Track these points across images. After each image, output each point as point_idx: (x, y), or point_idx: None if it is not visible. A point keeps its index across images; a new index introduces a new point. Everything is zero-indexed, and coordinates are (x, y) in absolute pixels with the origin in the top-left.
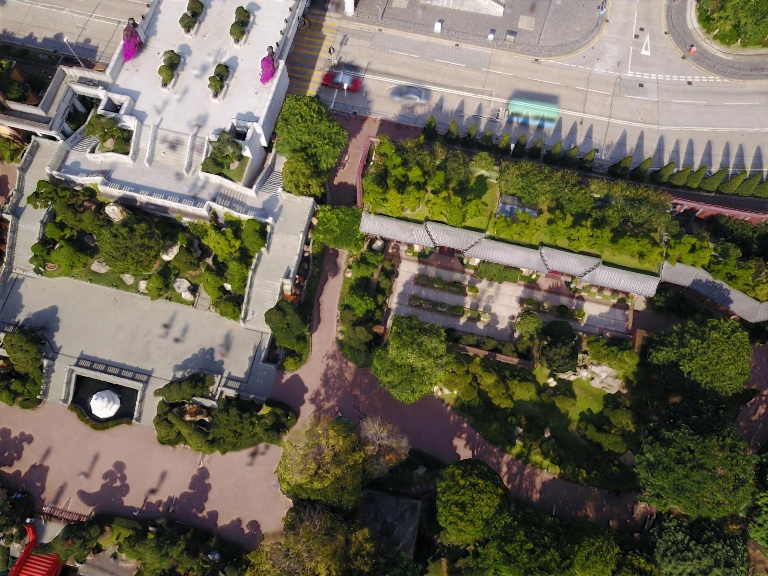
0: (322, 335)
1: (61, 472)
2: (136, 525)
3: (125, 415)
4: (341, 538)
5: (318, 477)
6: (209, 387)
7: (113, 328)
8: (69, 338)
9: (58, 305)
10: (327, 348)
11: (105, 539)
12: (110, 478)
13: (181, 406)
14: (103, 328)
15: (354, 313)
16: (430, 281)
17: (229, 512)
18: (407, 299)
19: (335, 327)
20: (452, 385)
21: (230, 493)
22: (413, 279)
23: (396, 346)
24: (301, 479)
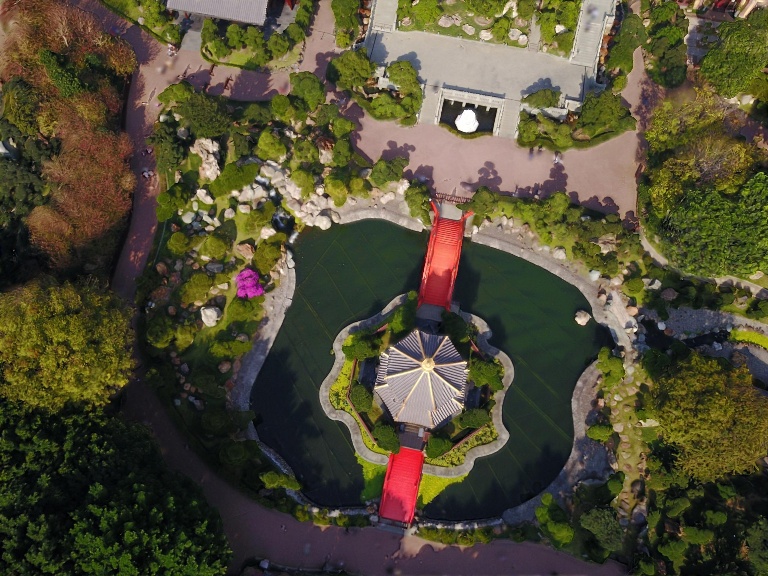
0: (633, 68)
1: (443, 170)
2: (518, 200)
3: (484, 130)
4: (742, 145)
5: (704, 117)
6: (557, 101)
7: (465, 66)
8: (431, 74)
9: (416, 51)
10: (640, 77)
11: (493, 213)
12: (484, 173)
13: (533, 118)
14: (456, 67)
15: (668, 42)
16: (710, 29)
17: (586, 192)
18: (694, 43)
19: (642, 62)
20: (756, 89)
21: (584, 179)
22: (696, 29)
23: (737, 36)
24: (691, 119)
